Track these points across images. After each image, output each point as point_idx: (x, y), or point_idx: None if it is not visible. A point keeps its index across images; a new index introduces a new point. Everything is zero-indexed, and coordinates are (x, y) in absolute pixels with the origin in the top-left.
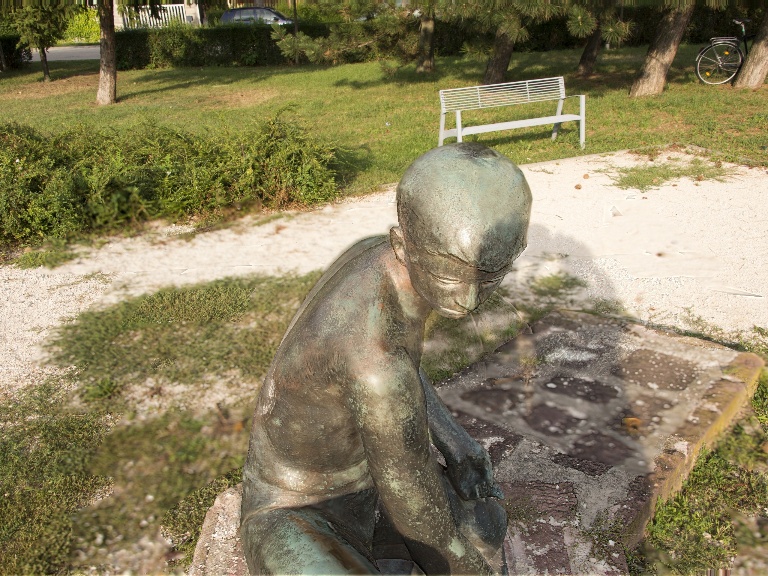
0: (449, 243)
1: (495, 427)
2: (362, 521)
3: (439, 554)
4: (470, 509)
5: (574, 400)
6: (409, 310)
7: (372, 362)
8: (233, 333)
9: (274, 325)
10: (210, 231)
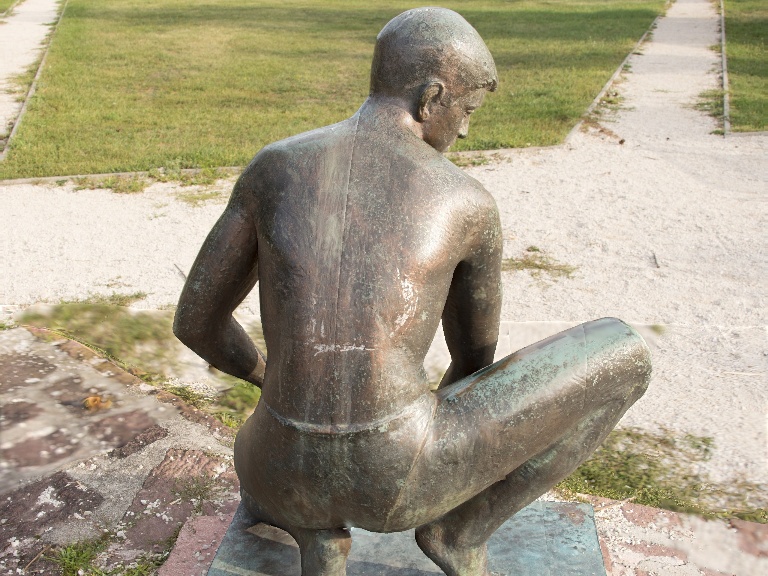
0: None
1: (21, 490)
2: None
3: None
4: None
5: (17, 428)
6: None
7: None
8: None
9: None
10: None
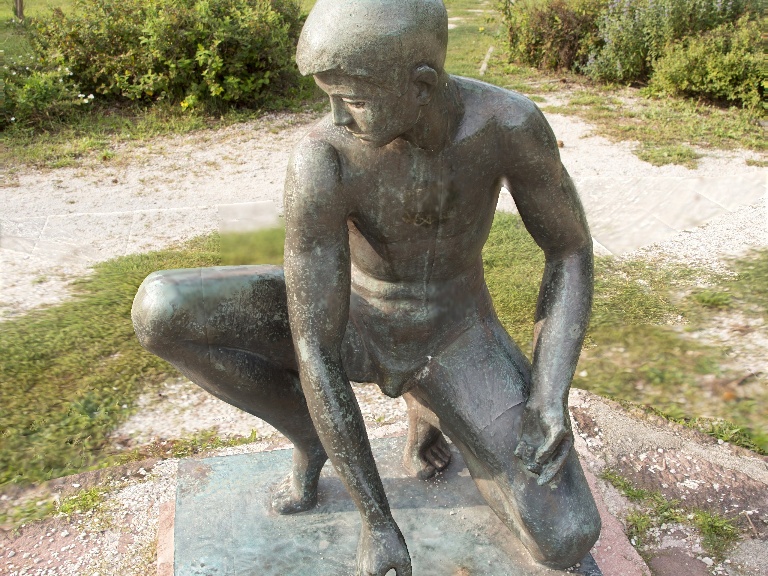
0: None
1: None
2: (375, 338)
3: (293, 342)
4: (525, 472)
5: None
6: None
7: None
8: None
9: None
10: None
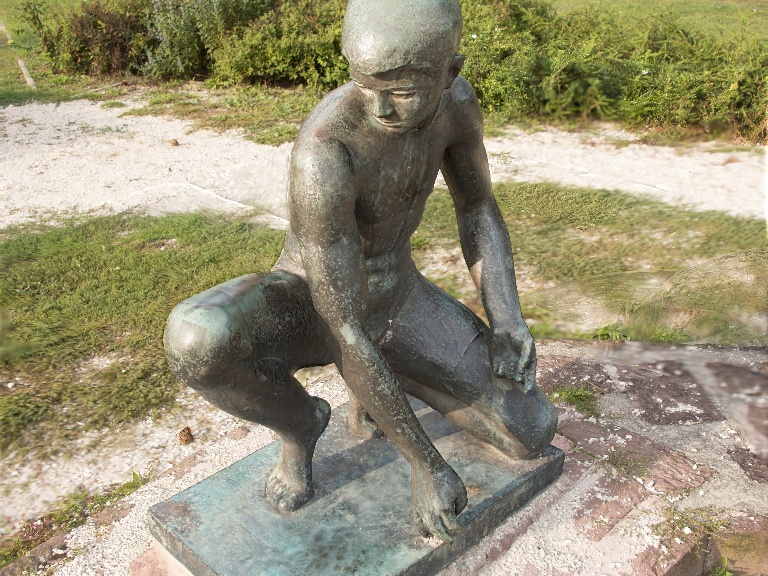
0: (343, 43)
1: (706, 399)
2: None
3: (331, 331)
4: (500, 388)
5: None
6: (374, 120)
7: (303, 142)
8: (567, 238)
9: (613, 245)
10: (650, 145)
